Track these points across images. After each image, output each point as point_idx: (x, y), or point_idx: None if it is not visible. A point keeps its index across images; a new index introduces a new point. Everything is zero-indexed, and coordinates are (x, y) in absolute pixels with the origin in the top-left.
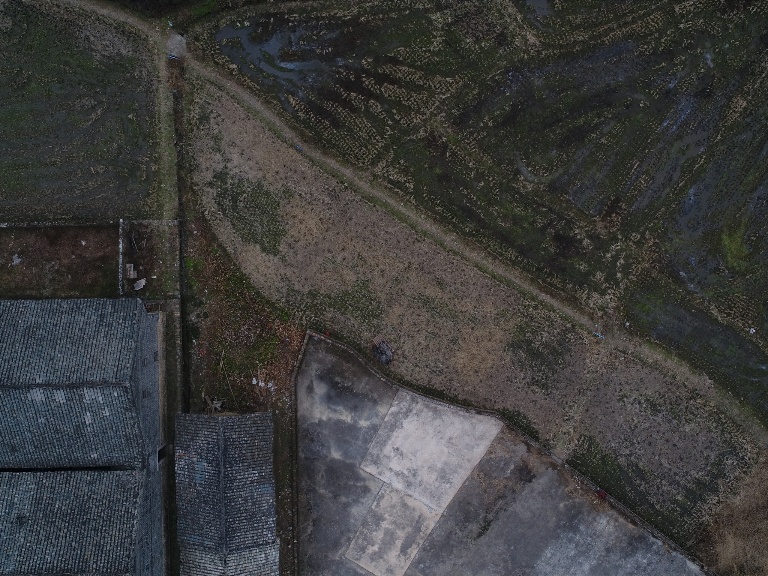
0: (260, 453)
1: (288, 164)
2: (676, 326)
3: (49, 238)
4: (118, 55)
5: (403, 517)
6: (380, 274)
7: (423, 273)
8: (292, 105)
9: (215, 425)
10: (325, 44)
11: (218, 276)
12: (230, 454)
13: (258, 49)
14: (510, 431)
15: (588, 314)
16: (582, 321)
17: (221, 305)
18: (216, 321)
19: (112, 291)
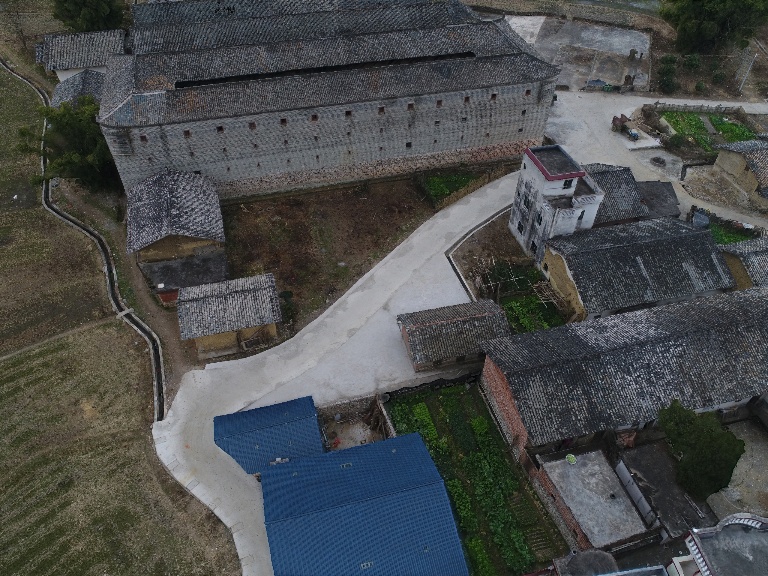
0: (469, 8)
1: None
2: (586, 3)
3: None
4: None
5: (526, 32)
6: (483, 2)
7: (497, 1)
8: None
9: (452, 0)
10: None
11: None
12: (460, 4)
13: None
14: (549, 17)
15: (556, 1)
16: (555, 2)
17: None
18: None
19: None
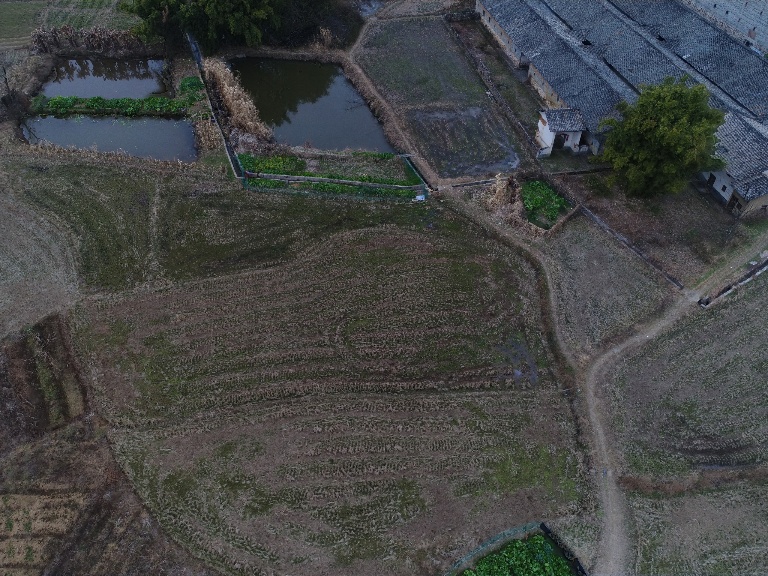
0: None
1: (410, 2)
2: None
3: (458, 33)
4: (380, 28)
5: None
6: None
7: None
8: (388, 4)
9: None
10: (364, 1)
11: (456, 6)
12: None
13: (369, 10)
14: None
15: None
16: None
17: (466, 5)
18: (473, 3)
19: (472, 22)
